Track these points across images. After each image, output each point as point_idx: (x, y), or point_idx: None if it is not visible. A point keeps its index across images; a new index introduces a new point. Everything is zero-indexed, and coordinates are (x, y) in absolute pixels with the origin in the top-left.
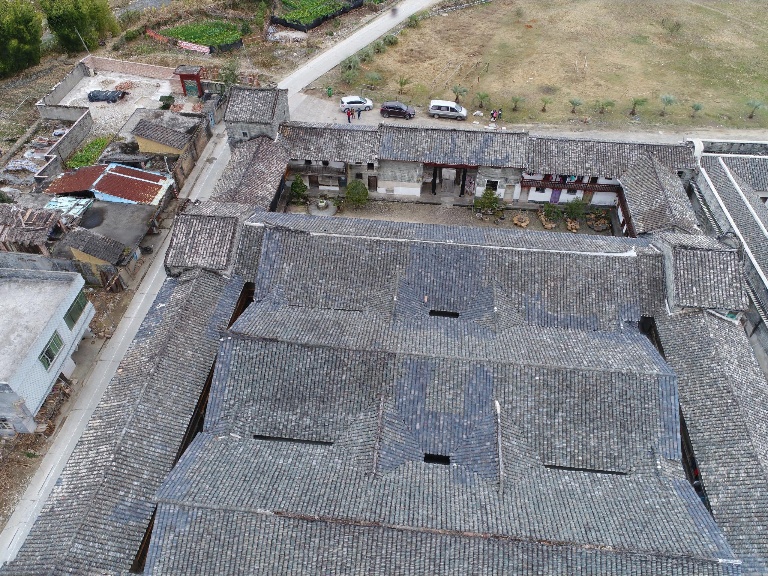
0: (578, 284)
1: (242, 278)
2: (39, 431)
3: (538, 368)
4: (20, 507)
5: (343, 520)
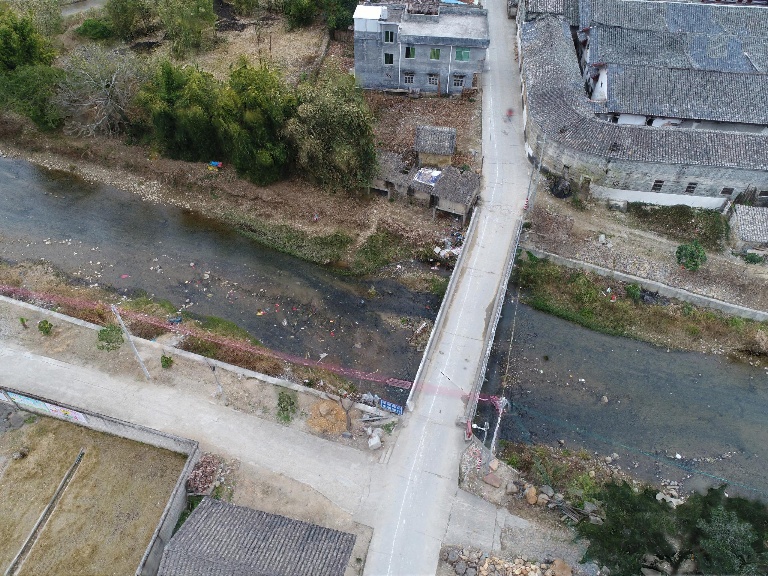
0: (767, 23)
1: (567, 23)
2: (474, 89)
3: (764, 39)
4: (484, 112)
5: (698, 69)
